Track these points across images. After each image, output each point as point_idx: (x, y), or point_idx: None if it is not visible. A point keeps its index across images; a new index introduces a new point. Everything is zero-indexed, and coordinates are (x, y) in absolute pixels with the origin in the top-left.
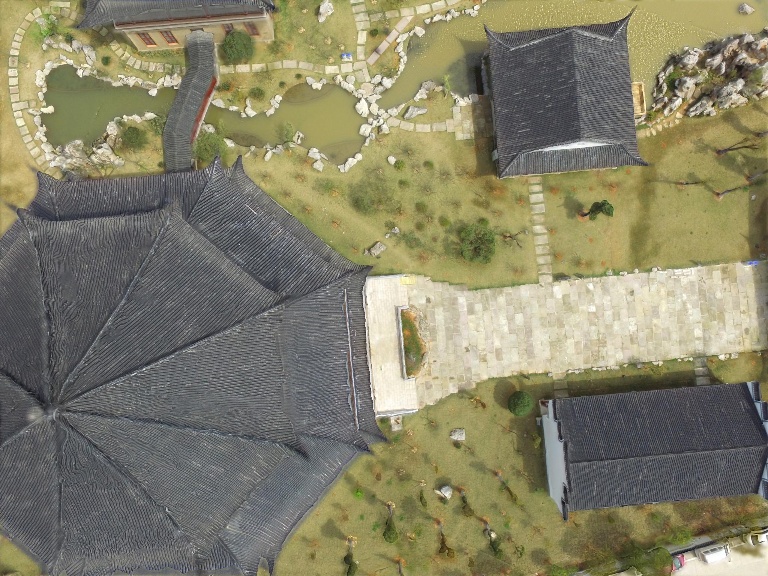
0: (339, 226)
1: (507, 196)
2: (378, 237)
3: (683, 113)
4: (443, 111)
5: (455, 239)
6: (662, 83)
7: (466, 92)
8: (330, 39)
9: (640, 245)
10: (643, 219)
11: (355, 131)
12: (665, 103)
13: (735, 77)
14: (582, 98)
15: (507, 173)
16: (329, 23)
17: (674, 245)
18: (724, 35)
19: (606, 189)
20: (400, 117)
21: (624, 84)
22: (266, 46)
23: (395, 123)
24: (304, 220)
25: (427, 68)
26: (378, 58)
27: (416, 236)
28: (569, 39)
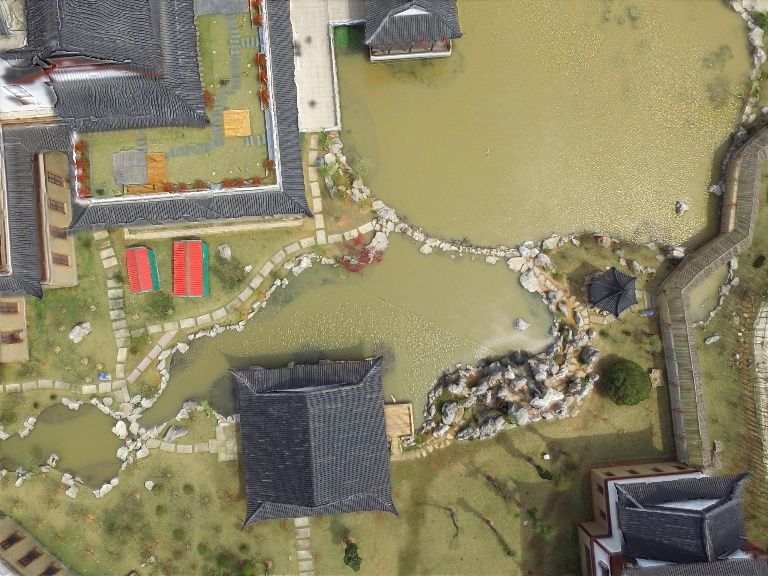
0: (93, 555)
1: (271, 520)
2: (134, 566)
3: (453, 435)
4: (206, 431)
5: (215, 567)
6: (432, 404)
7: (231, 410)
8: (87, 359)
9: (409, 571)
10: (412, 544)
11: (113, 453)
12: (433, 427)
13: (496, 413)
14: (317, 462)
15: (253, 520)
16: (86, 342)
17: (444, 571)
18: (499, 350)
19: (374, 513)
20: (161, 437)
21: (376, 427)
22: (21, 366)
23: (155, 445)
24: (57, 548)
25: (191, 384)
26: (139, 376)
27: (174, 564)
28: (303, 402)
